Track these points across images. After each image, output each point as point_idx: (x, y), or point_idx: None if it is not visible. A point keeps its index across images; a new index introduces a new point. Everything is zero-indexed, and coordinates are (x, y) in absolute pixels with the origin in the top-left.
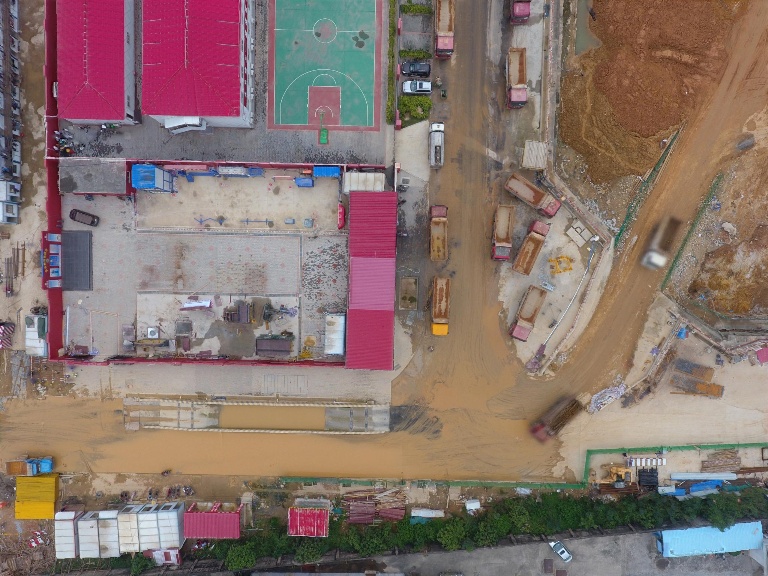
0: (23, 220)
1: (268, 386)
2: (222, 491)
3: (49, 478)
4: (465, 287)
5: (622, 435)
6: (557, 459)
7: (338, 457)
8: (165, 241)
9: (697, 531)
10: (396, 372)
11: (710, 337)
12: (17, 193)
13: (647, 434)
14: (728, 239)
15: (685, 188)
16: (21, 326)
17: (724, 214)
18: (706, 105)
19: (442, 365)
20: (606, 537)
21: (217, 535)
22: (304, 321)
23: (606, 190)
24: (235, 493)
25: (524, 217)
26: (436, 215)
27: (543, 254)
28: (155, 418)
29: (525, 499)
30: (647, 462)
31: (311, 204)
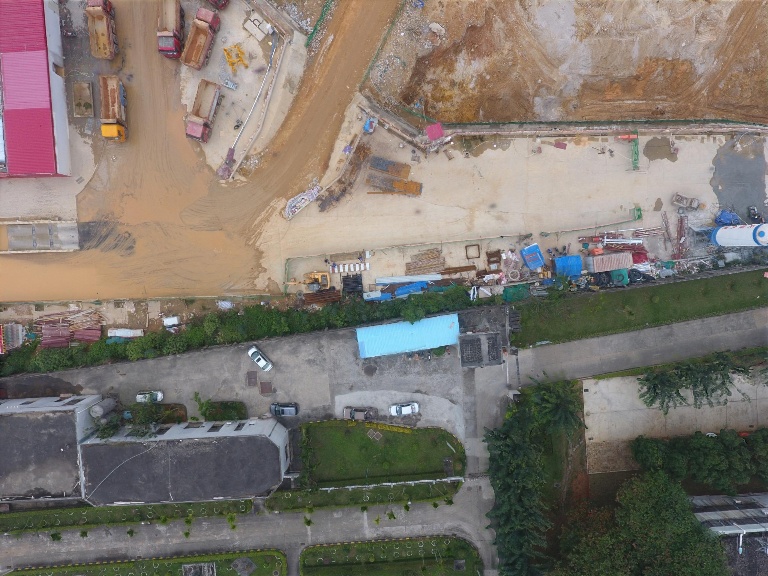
0: None
1: None
2: None
3: None
4: (145, 91)
5: (323, 241)
6: (259, 270)
7: (28, 280)
8: None
9: (392, 328)
10: (79, 186)
11: (404, 132)
12: None
13: (348, 239)
14: (436, 40)
15: None
16: None
17: (432, 14)
18: None
19: (129, 176)
20: (310, 345)
21: None
22: None
23: None
24: None
25: None
26: (91, 5)
27: (223, 51)
28: None
29: (225, 312)
30: (350, 267)
31: None
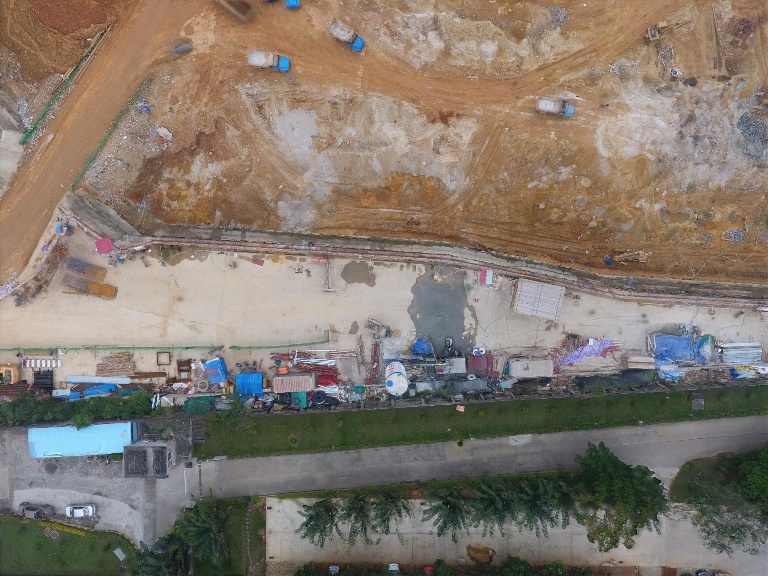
0: None
1: None
2: None
3: None
4: None
5: (18, 335)
6: None
7: None
8: None
9: (64, 431)
10: None
11: (103, 236)
12: None
13: (43, 335)
14: (162, 144)
15: (110, 89)
16: None
17: (162, 119)
18: (140, 7)
19: None
20: None
21: None
22: None
23: (38, 90)
24: None
25: None
26: None
27: None
28: None
29: None
30: (42, 363)
31: None
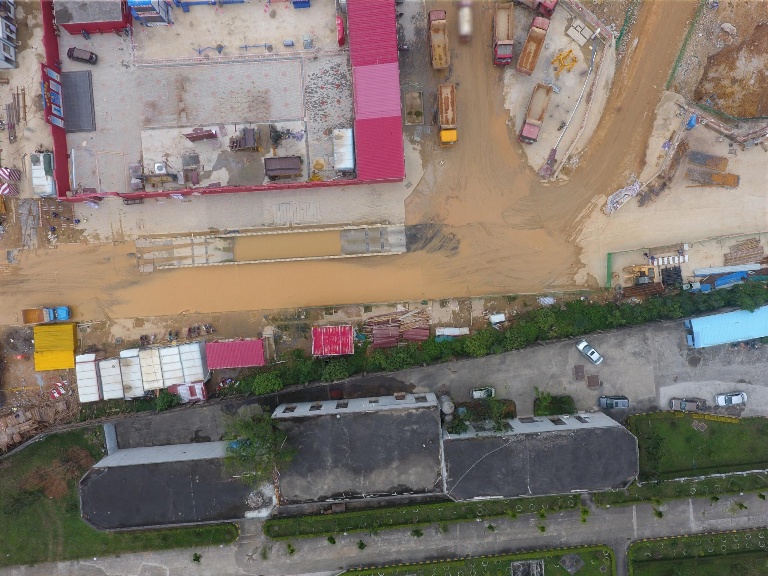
0: (21, 64)
1: (280, 216)
2: (242, 327)
3: (66, 325)
4: (470, 98)
5: (641, 235)
6: (578, 266)
7: (357, 283)
8: (165, 75)
9: (726, 317)
10: (408, 190)
11: (720, 127)
12: (13, 34)
13: (666, 232)
14: (729, 39)
15: None
16: (27, 173)
17: (722, 15)
18: None
19: (454, 180)
20: (635, 338)
21: (241, 363)
22: (311, 145)
23: (602, 0)
24: (256, 328)
25: (523, 22)
26: (435, 19)
27: (545, 57)
28: (169, 258)
29: (549, 308)
30: (669, 260)
31: (308, 25)
